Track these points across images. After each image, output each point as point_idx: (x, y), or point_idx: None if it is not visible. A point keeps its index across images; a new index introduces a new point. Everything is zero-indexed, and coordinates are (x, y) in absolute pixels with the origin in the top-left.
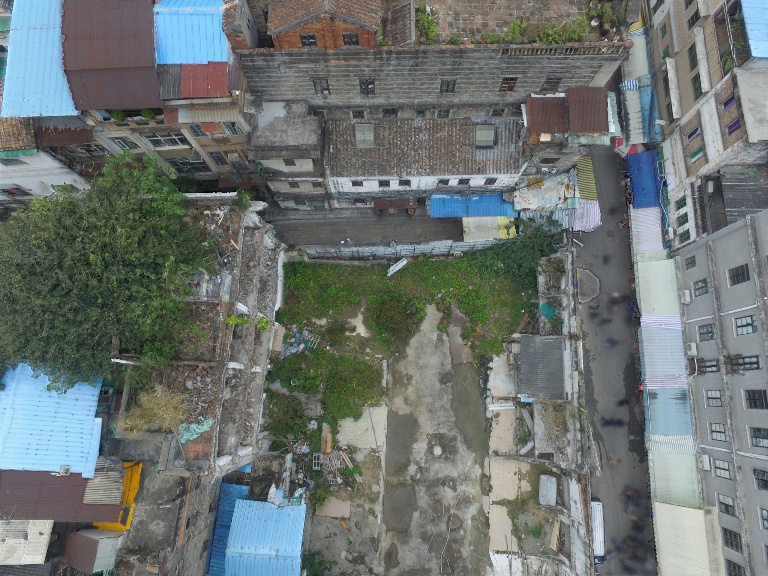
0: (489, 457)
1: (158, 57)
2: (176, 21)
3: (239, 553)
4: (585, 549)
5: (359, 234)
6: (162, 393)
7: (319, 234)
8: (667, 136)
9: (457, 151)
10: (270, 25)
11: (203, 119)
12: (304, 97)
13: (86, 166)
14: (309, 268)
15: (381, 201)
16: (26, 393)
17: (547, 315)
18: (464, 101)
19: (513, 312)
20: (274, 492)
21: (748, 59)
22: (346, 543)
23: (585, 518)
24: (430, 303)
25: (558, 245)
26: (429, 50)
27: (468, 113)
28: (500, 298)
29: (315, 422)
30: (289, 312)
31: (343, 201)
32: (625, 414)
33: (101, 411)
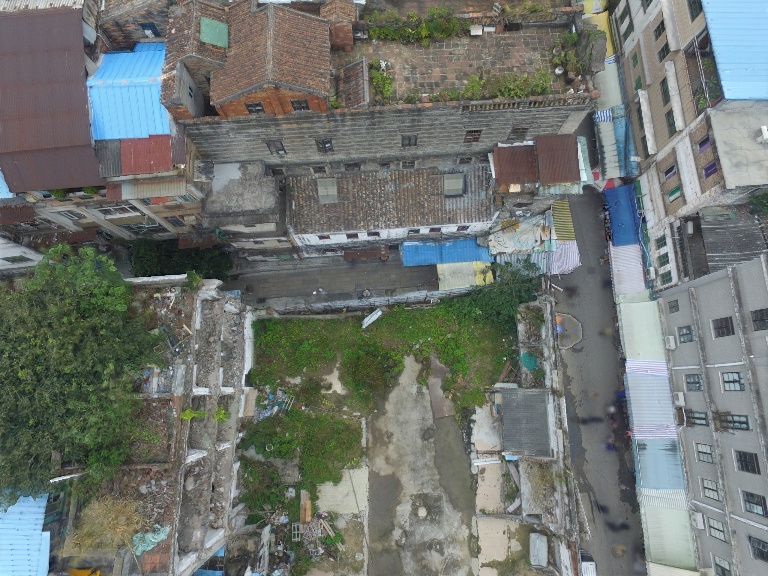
0: (476, 516)
1: (95, 133)
2: (112, 94)
3: None
4: None
5: (331, 283)
6: (114, 501)
7: (290, 285)
8: (644, 171)
9: (425, 201)
10: (212, 95)
11: (148, 194)
12: (259, 158)
13: (34, 237)
14: (280, 324)
15: (351, 251)
16: None
17: (529, 366)
18: (428, 153)
19: (494, 360)
20: None
21: (721, 100)
22: None
23: None
24: (408, 354)
25: (536, 294)
26: (385, 111)
27: (434, 163)
28: (480, 346)
29: (293, 489)
30: (261, 372)
31: (312, 252)
32: (615, 462)
33: (50, 521)
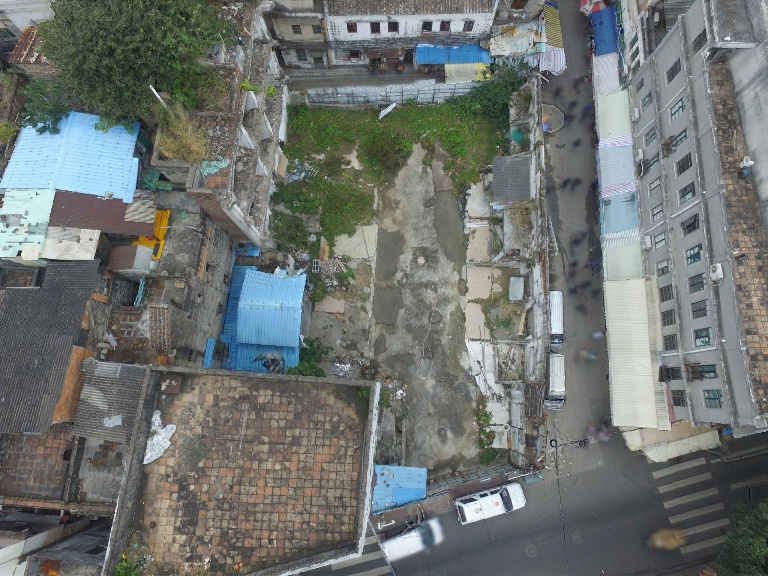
0: (466, 265)
1: None
2: None
3: (249, 305)
4: (543, 309)
5: None
6: None
7: None
8: None
9: None
10: None
11: None
12: None
13: None
14: (310, 112)
15: (373, 50)
16: (77, 136)
17: (517, 139)
18: None
19: (489, 147)
20: (279, 271)
21: None
22: (341, 333)
23: (544, 284)
24: (416, 142)
25: (526, 75)
26: None
27: None
28: (478, 136)
29: (314, 236)
30: (292, 148)
31: (340, 55)
32: (586, 232)
33: None
